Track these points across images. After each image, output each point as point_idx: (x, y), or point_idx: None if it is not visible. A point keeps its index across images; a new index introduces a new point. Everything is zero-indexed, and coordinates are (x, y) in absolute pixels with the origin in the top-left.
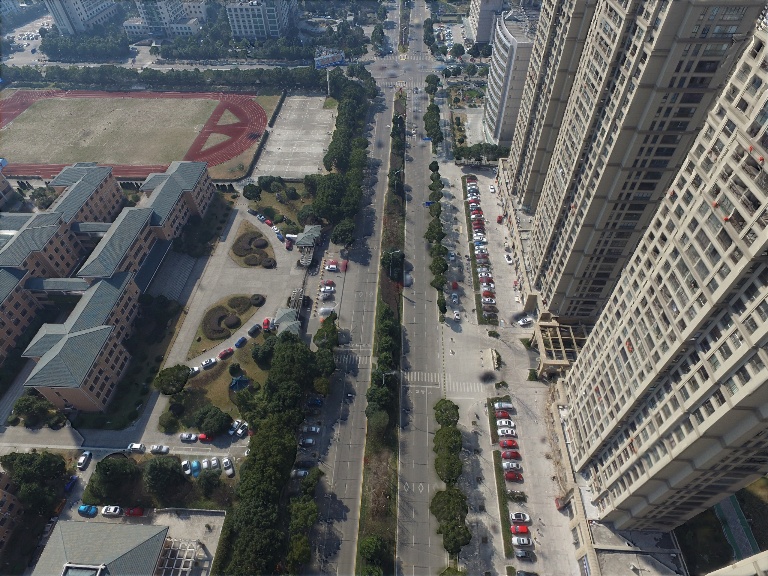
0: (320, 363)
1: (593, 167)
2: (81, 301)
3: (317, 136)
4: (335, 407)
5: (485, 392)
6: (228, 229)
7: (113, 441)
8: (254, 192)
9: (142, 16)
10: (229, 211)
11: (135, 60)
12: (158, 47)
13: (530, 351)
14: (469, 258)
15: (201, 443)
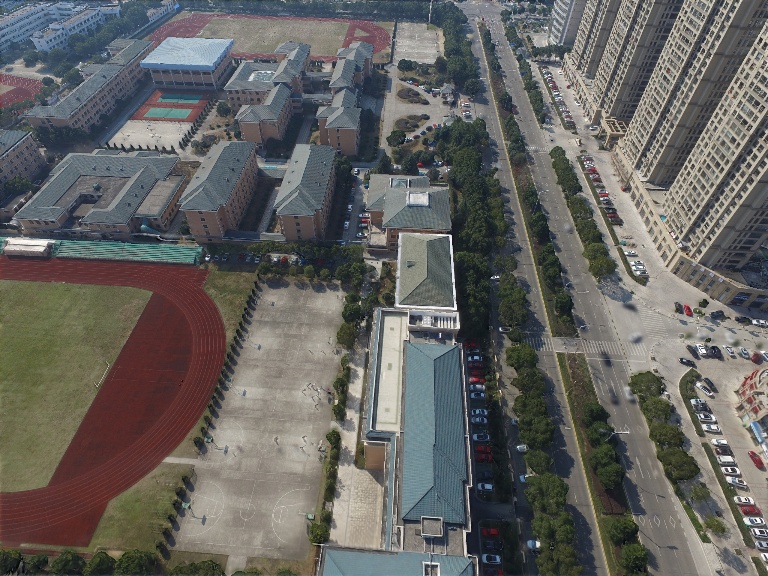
0: (481, 132)
1: (646, 8)
2: (336, 98)
3: (430, 44)
4: (489, 158)
5: (574, 154)
6: (390, 87)
7: (368, 166)
8: (407, 64)
9: None
10: (386, 79)
11: None
12: None
13: (598, 140)
14: (552, 103)
15: (419, 168)
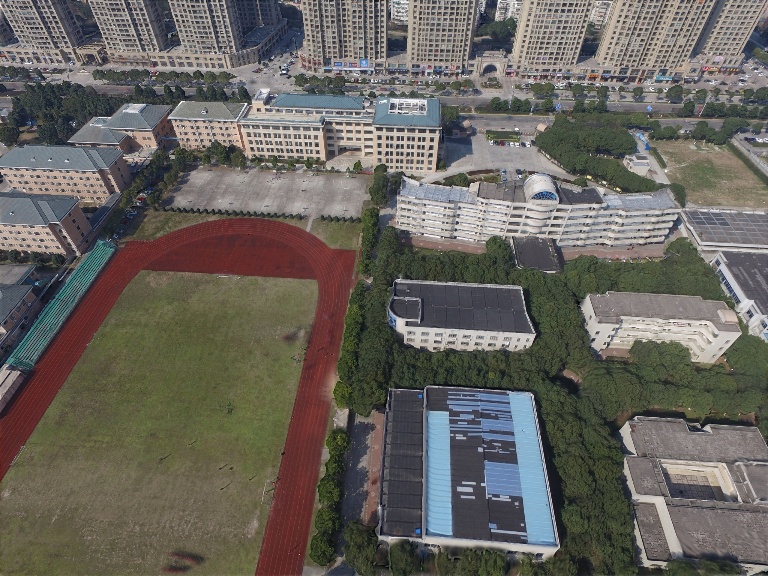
0: None
1: None
2: None
3: None
4: None
5: None
6: None
7: None
8: None
9: None
10: None
11: None
12: None
13: (88, 65)
14: None
15: None
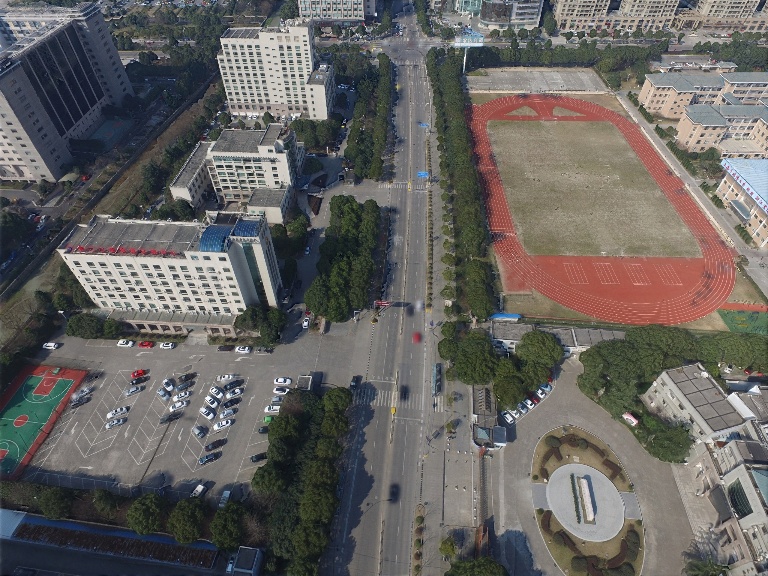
0: None
1: None
2: None
3: (536, 75)
4: None
5: (710, 38)
6: None
7: None
8: None
9: (289, 172)
10: None
11: (418, 175)
12: (351, 177)
13: None
14: None
15: None
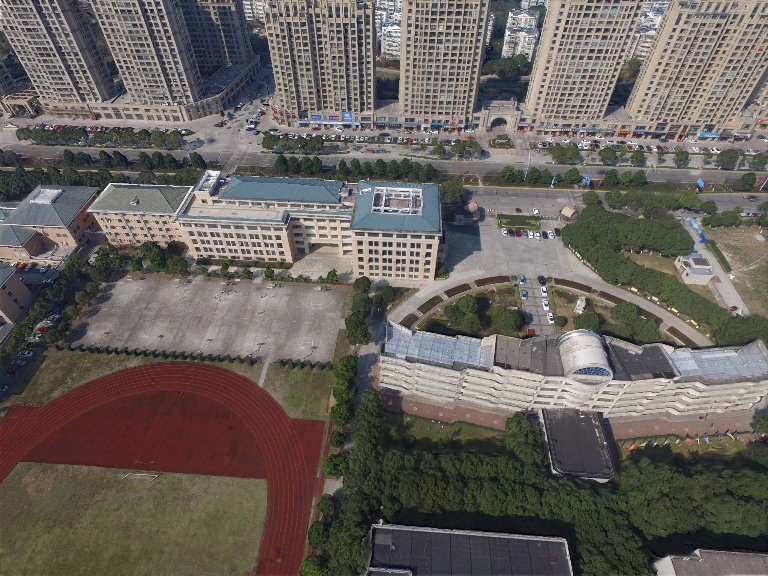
0: None
1: None
2: None
3: None
4: None
5: None
6: None
7: None
8: None
9: None
10: None
11: None
12: None
13: (18, 117)
14: None
15: None
